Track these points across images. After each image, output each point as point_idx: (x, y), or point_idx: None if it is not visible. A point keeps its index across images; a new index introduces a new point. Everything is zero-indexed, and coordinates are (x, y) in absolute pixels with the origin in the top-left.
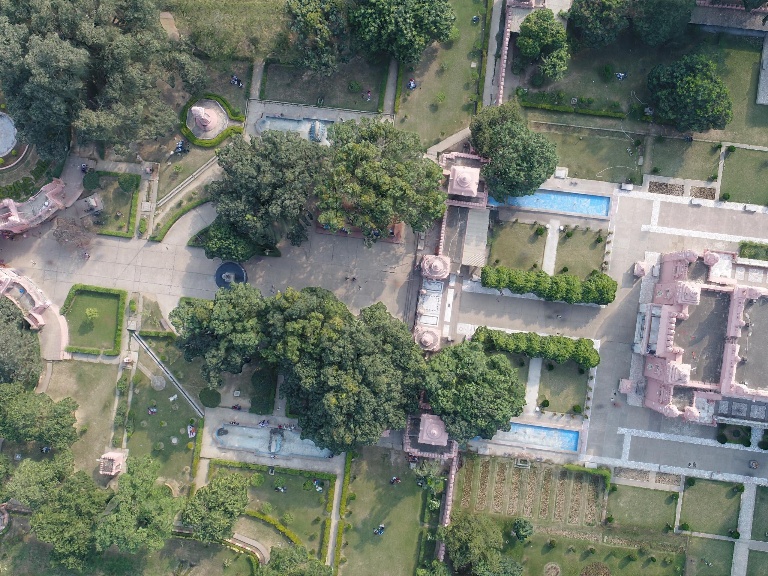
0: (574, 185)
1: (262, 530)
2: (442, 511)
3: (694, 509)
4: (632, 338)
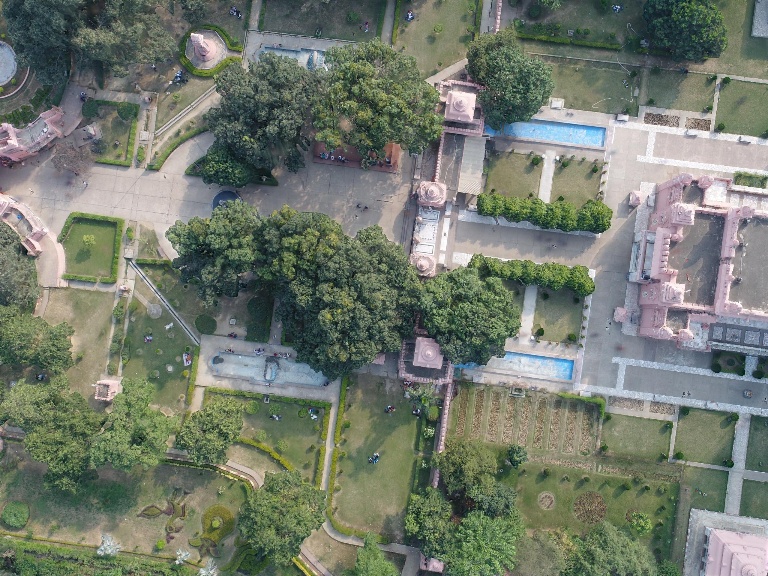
0: (570, 116)
1: (256, 458)
2: (437, 440)
3: (688, 438)
4: (627, 268)
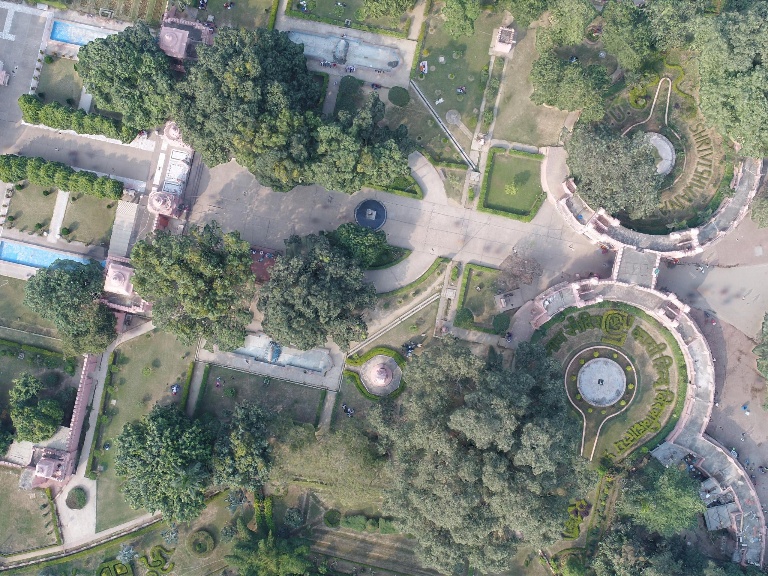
0: (31, 274)
1: None
2: None
3: None
4: None
